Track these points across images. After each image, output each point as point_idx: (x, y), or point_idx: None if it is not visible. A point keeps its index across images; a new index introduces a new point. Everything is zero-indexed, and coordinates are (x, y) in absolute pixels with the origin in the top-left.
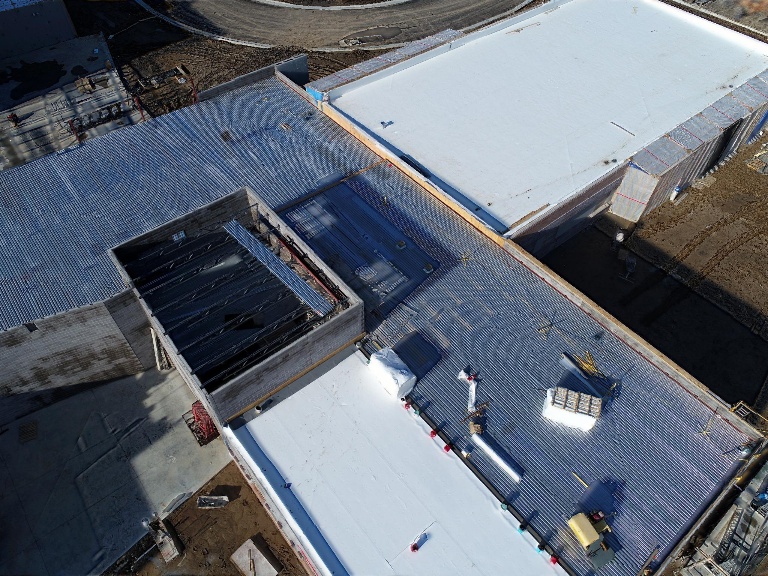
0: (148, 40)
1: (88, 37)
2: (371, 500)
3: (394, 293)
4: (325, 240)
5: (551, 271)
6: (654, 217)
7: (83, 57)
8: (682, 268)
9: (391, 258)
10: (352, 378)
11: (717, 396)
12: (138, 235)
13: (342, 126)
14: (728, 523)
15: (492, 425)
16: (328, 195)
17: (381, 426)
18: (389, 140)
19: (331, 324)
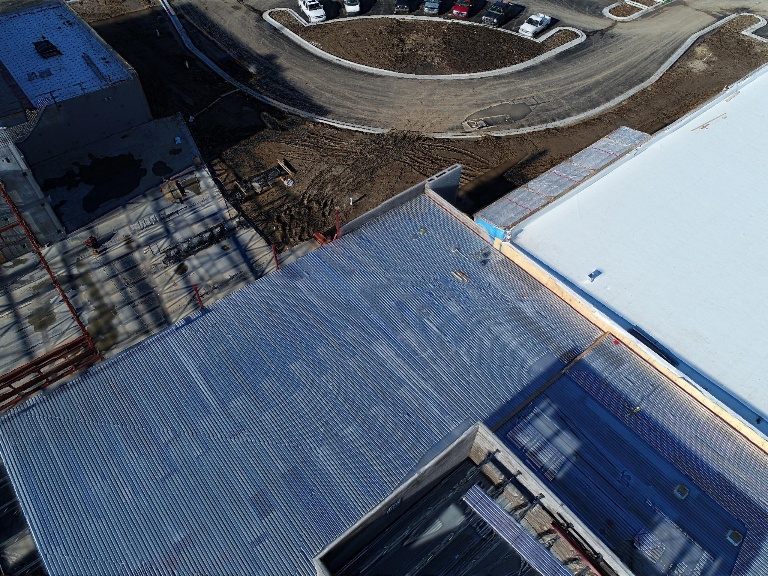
0: (236, 123)
1: (165, 120)
2: None
3: None
4: (574, 482)
5: None
6: None
7: (163, 149)
8: None
9: (675, 516)
10: None
11: None
12: (352, 527)
13: (532, 275)
14: None
15: None
16: (552, 397)
17: None
18: (604, 301)
19: None
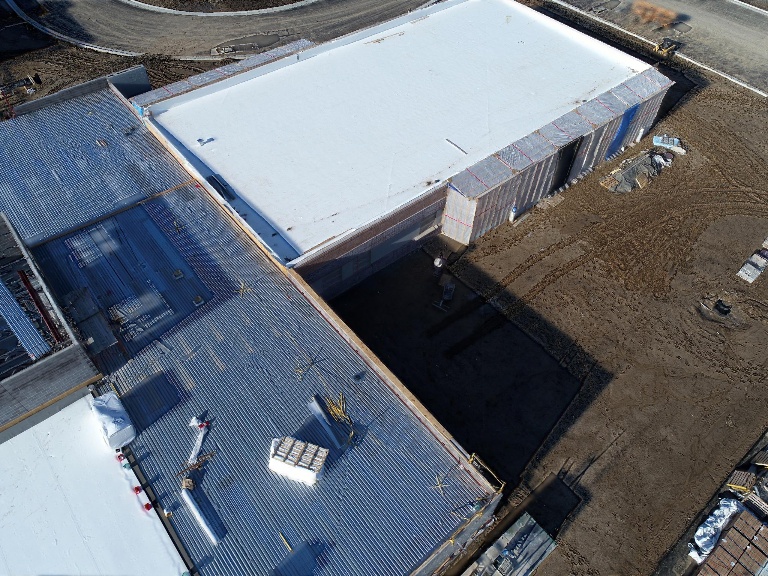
0: (9, 47)
1: None
2: (43, 568)
3: (152, 328)
4: (98, 269)
5: (325, 304)
6: (488, 239)
7: None
8: (503, 295)
9: (163, 289)
10: (71, 426)
11: (459, 445)
12: None
13: (161, 143)
14: None
15: (209, 479)
16: (119, 219)
17: (85, 481)
18: (203, 159)
19: (35, 370)
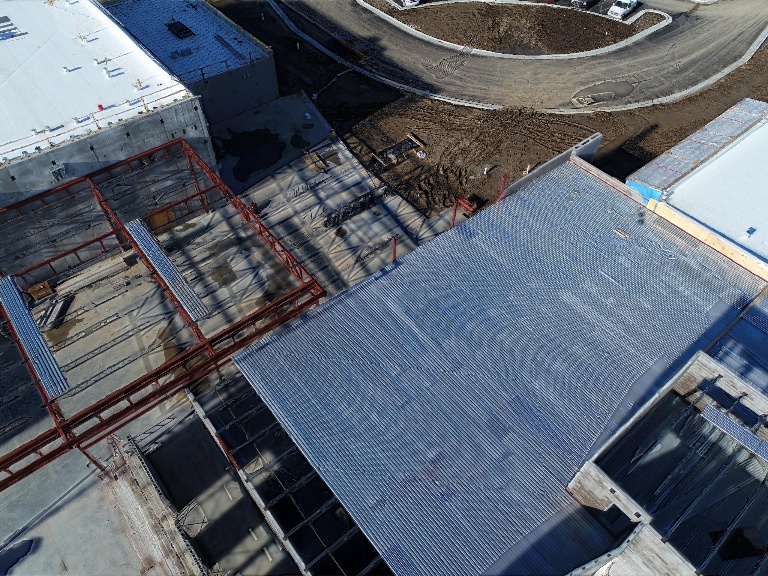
0: (358, 100)
1: (291, 97)
2: None
3: None
4: None
5: None
6: None
7: (296, 124)
8: None
9: None
10: None
11: None
12: (613, 436)
13: (689, 232)
14: None
15: None
16: (736, 338)
17: None
18: (764, 255)
19: None
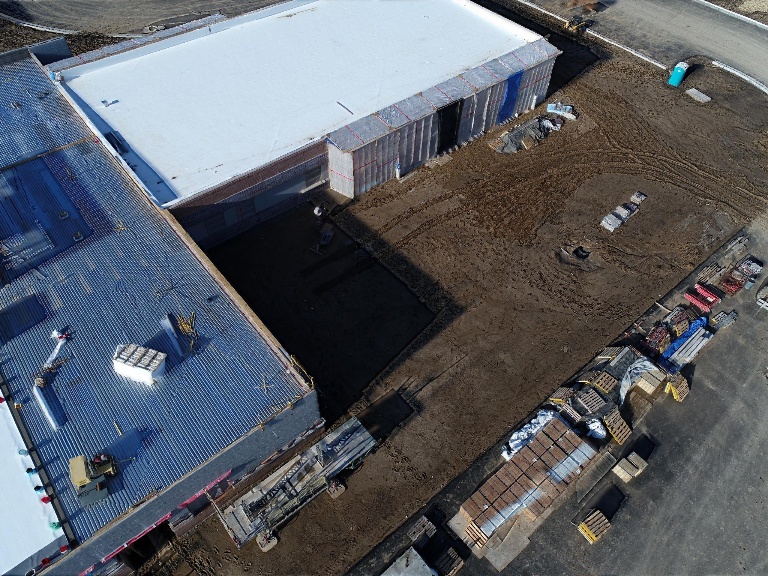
0: None
1: None
2: None
3: (32, 259)
4: None
5: (190, 239)
6: (374, 194)
7: None
8: (378, 241)
9: (48, 227)
10: None
11: (286, 352)
12: None
13: (71, 105)
14: (285, 472)
15: (60, 379)
16: (19, 169)
17: None
18: (105, 118)
19: None
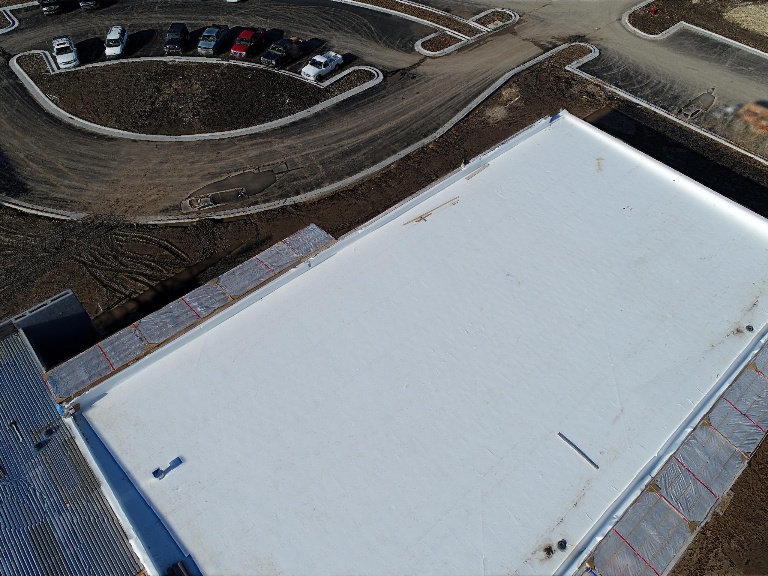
0: None
1: None
2: None
3: None
4: None
5: None
6: None
7: None
8: None
9: None
10: None
11: None
12: None
13: None
14: None
15: None
16: None
17: None
18: (162, 514)
19: None
